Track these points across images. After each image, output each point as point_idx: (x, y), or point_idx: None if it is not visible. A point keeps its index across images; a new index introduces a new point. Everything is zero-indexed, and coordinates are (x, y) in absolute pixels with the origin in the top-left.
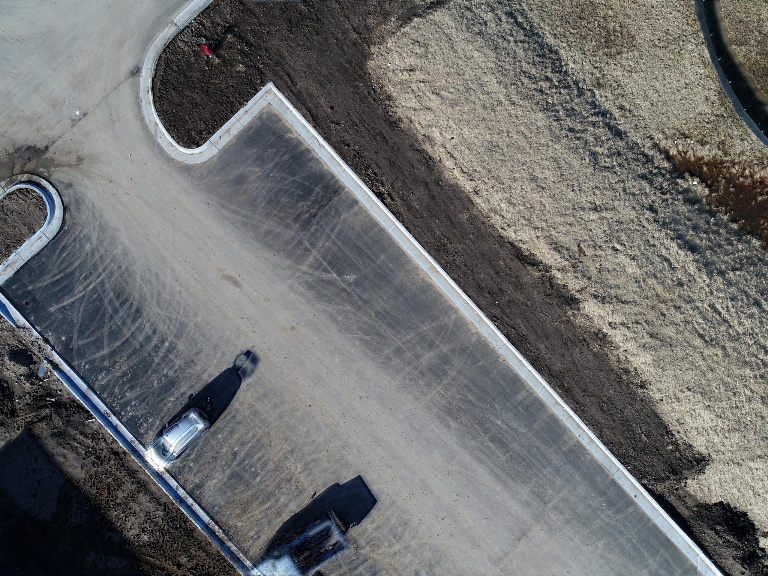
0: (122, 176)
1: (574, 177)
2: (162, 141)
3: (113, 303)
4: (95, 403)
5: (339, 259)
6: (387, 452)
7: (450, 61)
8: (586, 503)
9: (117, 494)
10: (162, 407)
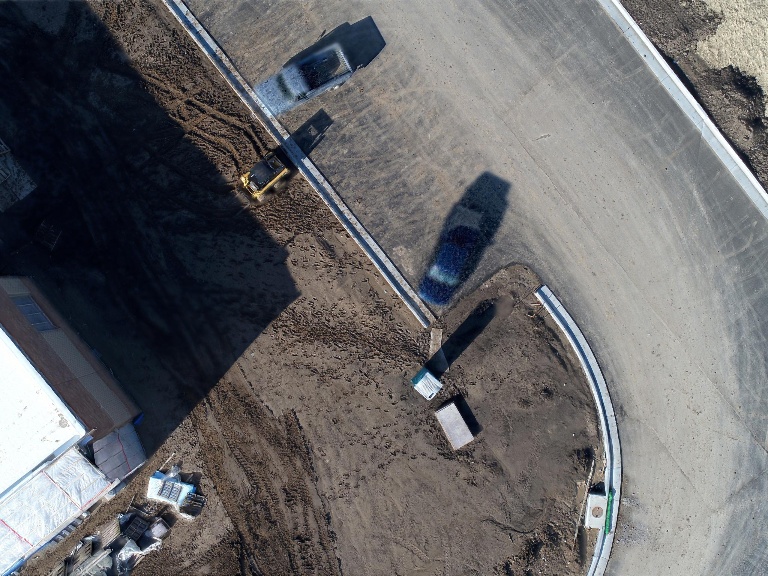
0: None
1: None
2: None
3: None
4: None
5: None
6: None
7: None
8: (595, 60)
9: (127, 15)
10: None
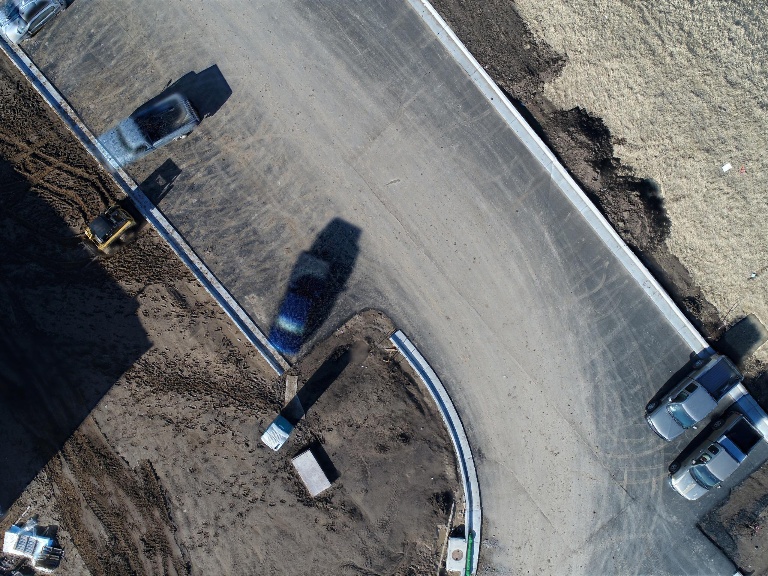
0: None
1: None
2: None
3: None
4: None
5: None
6: (244, 42)
7: None
8: (442, 104)
9: None
10: None
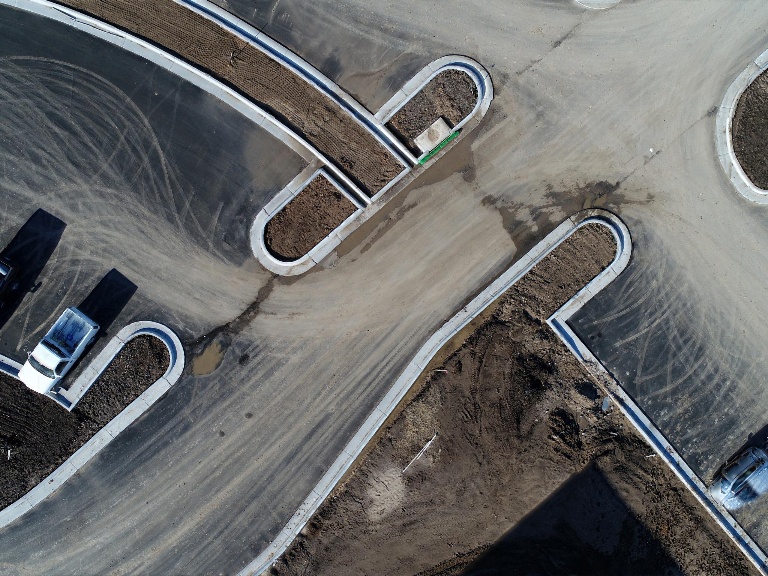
0: (692, 214)
1: None
2: (736, 181)
3: (677, 340)
4: (658, 439)
5: None
6: None
7: None
8: None
9: (676, 529)
10: (722, 445)
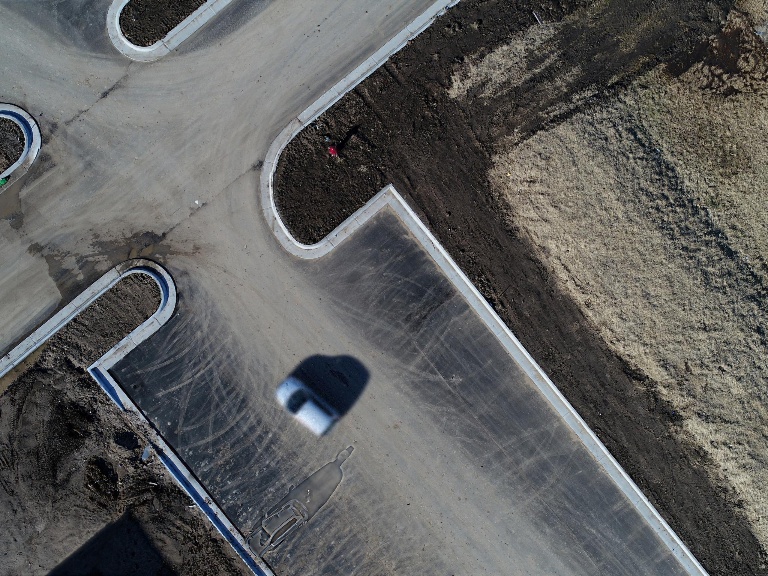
0: (237, 267)
1: (685, 296)
2: (279, 235)
3: (220, 391)
4: (197, 490)
5: (446, 361)
6: (482, 554)
7: (570, 175)
8: None
9: None
10: (262, 497)
